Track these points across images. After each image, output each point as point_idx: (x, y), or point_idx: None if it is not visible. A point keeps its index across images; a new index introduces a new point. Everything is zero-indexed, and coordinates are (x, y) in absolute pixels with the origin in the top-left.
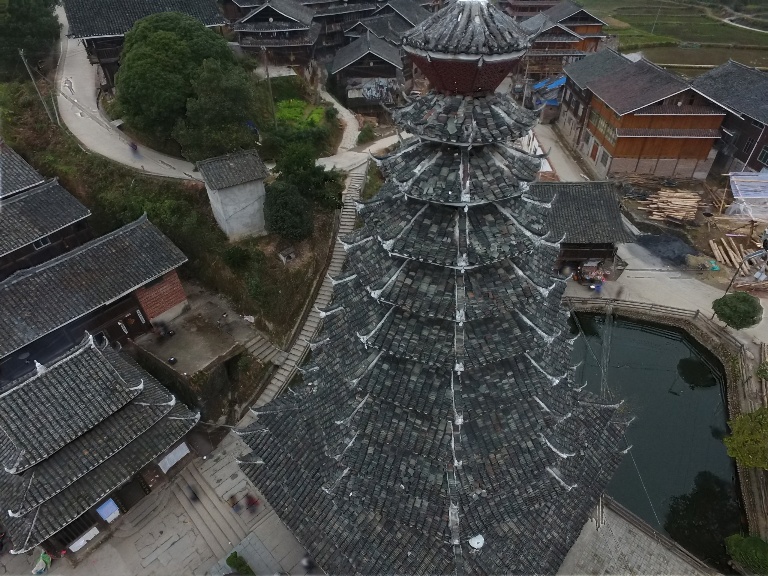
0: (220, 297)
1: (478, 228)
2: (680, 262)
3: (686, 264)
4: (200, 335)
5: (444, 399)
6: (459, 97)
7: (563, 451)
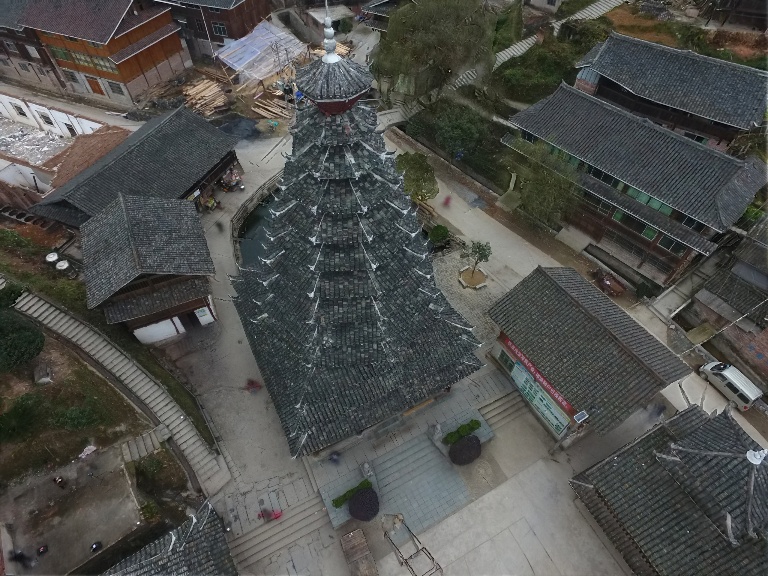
0: (17, 484)
1: (379, 169)
2: (257, 133)
3: (261, 132)
4: (73, 513)
5: (410, 257)
6: (349, 111)
7: (425, 242)
